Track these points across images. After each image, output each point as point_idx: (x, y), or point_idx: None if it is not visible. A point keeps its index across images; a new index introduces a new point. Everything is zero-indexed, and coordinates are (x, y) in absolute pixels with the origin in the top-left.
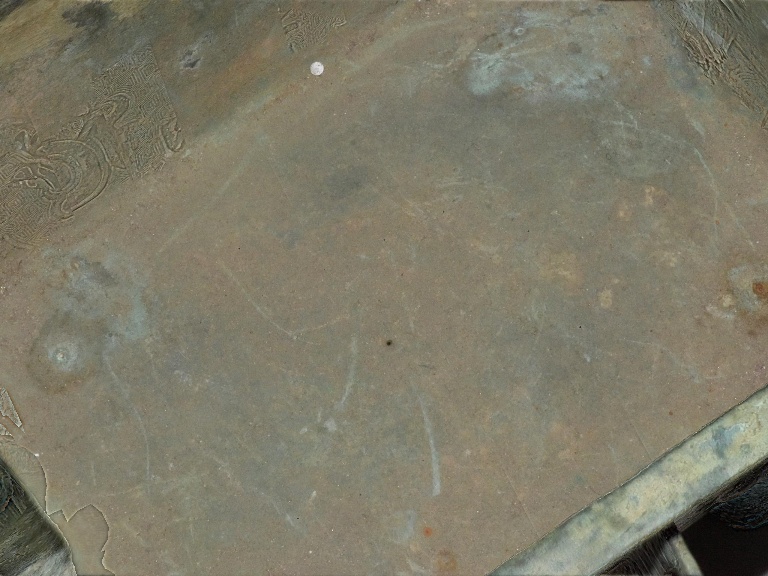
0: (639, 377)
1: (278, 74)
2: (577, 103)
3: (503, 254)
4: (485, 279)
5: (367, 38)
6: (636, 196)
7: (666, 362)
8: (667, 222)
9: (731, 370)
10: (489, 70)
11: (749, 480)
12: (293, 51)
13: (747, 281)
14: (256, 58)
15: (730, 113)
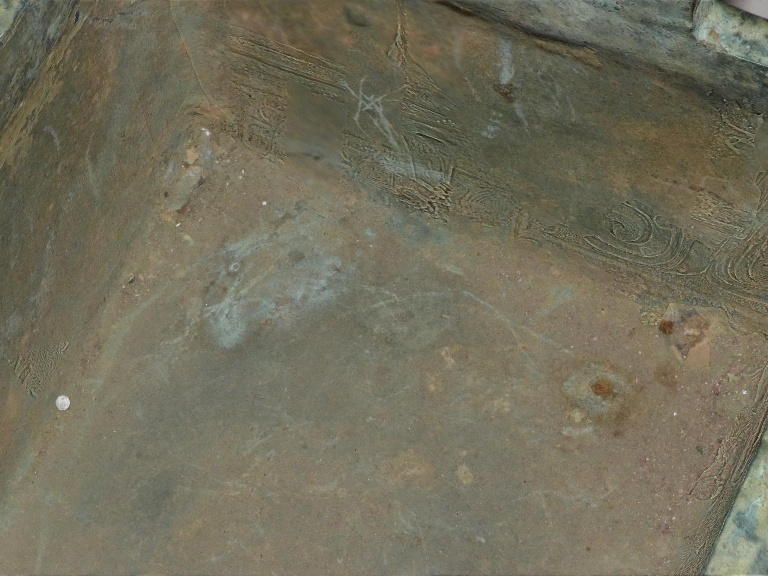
0: (539, 531)
1: (30, 427)
2: (329, 306)
3: (345, 485)
4: (342, 517)
5: (94, 349)
6: (436, 364)
7: (556, 504)
8: (478, 373)
9: (619, 478)
10: (228, 318)
11: None
12: (34, 397)
13: (584, 388)
14: (6, 422)
15: (476, 241)
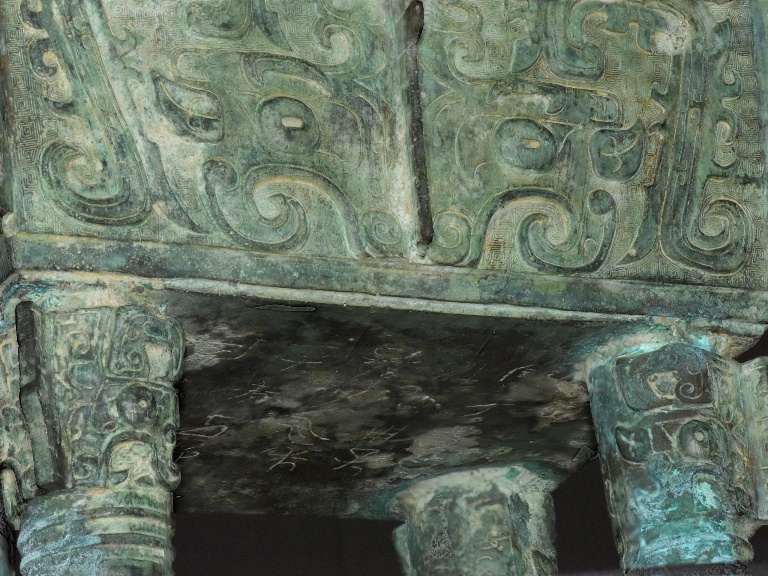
0: None
1: None
2: None
3: None
4: None
5: None
6: None
7: None
8: None
9: None
10: None
11: (511, 83)
12: None
13: None
14: None
15: None
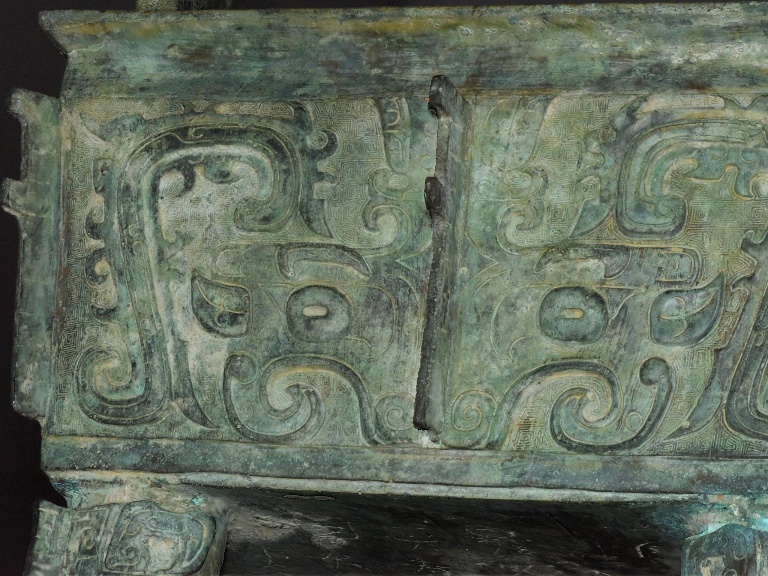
0: None
1: None
2: None
3: None
4: None
5: None
6: None
7: None
8: None
9: None
10: None
11: (563, 249)
12: None
13: None
14: None
15: None
